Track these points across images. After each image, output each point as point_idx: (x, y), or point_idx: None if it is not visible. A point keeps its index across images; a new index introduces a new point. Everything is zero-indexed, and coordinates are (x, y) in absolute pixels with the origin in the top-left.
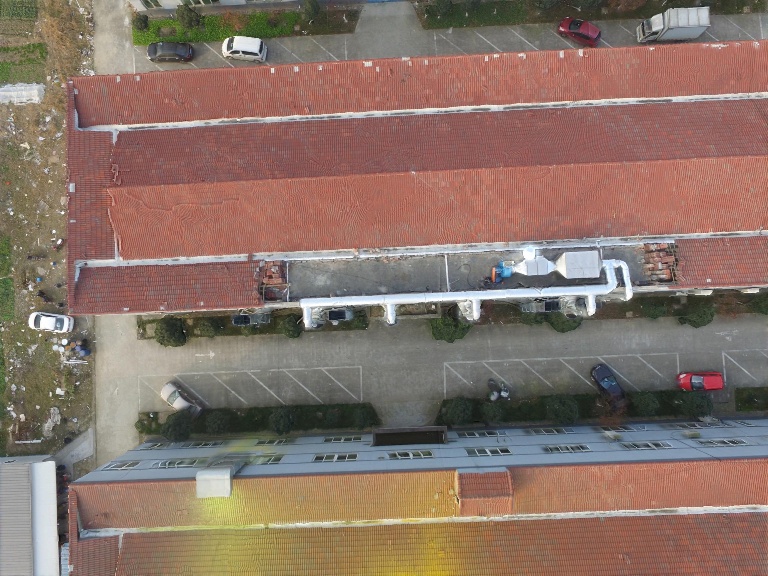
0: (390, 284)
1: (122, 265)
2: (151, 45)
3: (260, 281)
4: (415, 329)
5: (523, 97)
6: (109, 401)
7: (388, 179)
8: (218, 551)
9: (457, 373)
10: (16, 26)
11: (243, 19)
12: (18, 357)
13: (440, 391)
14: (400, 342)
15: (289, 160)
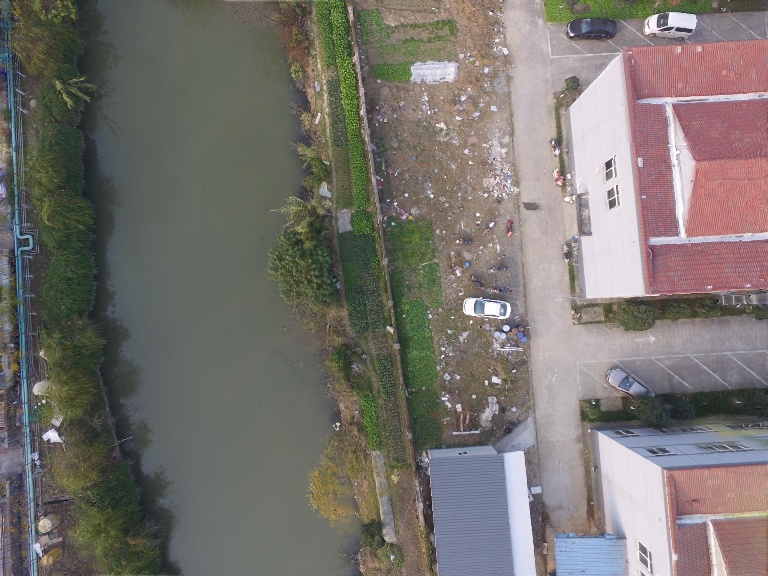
0: None
1: (686, 242)
2: (574, 22)
3: None
4: None
5: None
6: (547, 389)
7: None
8: None
9: None
10: (422, 2)
11: None
12: (449, 345)
13: None
14: None
15: None
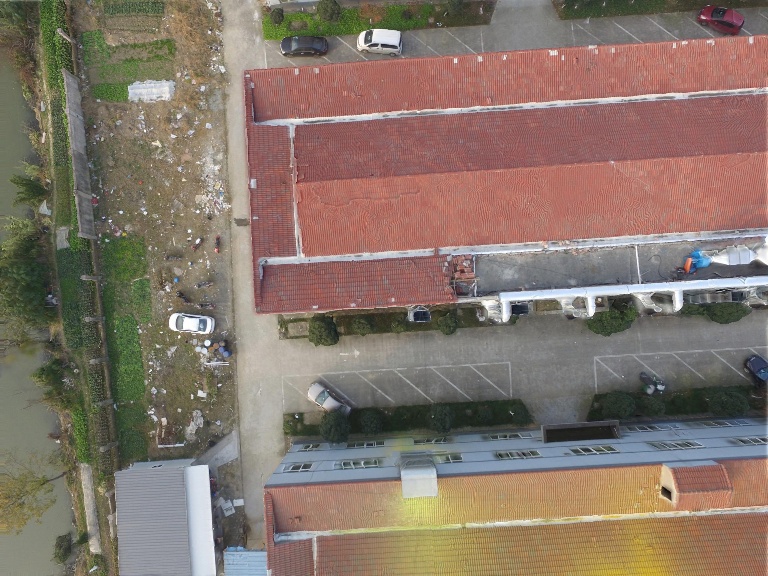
0: (580, 277)
1: (304, 262)
2: (285, 39)
3: (450, 276)
4: (563, 323)
5: (710, 84)
6: (252, 402)
7: (583, 169)
8: (418, 552)
9: (608, 367)
10: (142, 22)
11: (376, 12)
12: (157, 359)
13: (591, 386)
14: (549, 337)
15: (474, 152)
